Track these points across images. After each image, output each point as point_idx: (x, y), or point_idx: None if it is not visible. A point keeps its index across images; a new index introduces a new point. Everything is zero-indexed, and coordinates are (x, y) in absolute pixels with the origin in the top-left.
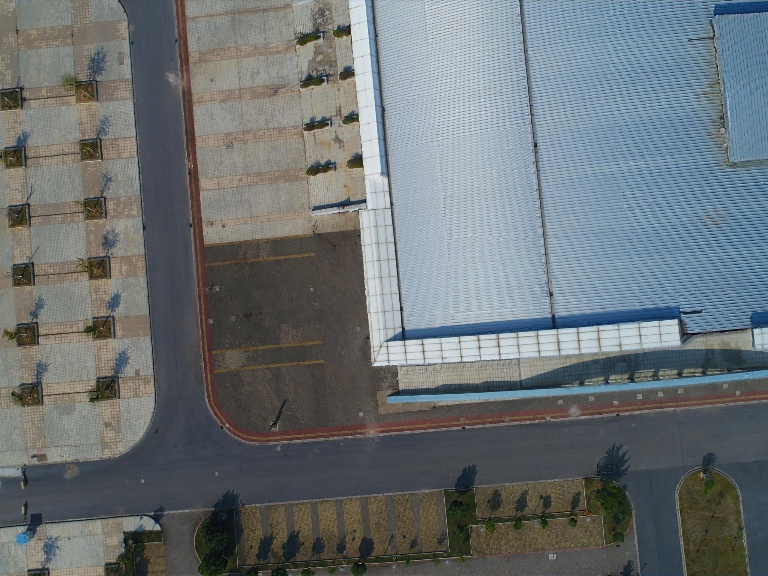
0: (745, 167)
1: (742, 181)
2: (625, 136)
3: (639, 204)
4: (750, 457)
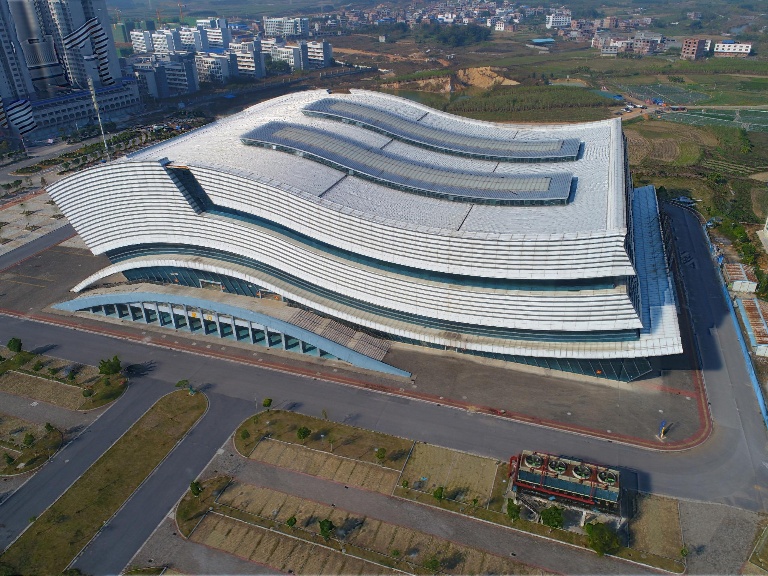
0: None
1: None
2: None
3: None
4: (235, 395)
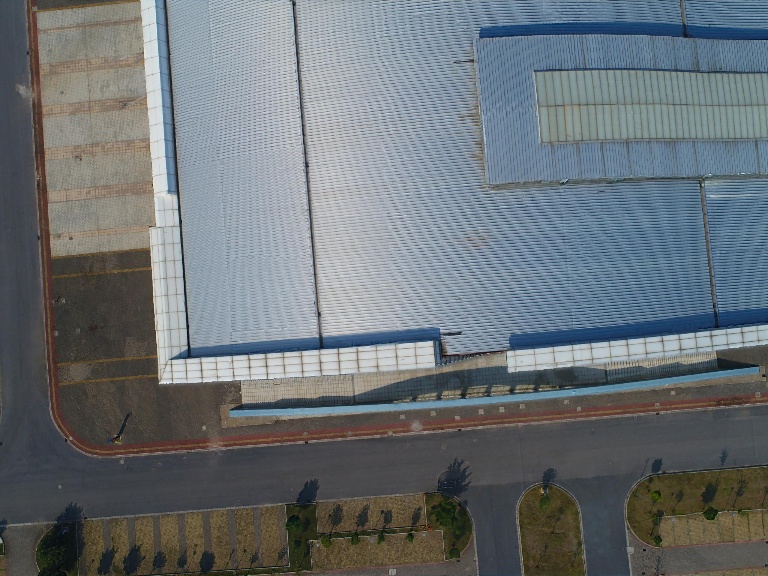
0: (507, 189)
1: (504, 203)
2: (390, 157)
3: (403, 225)
4: (590, 473)
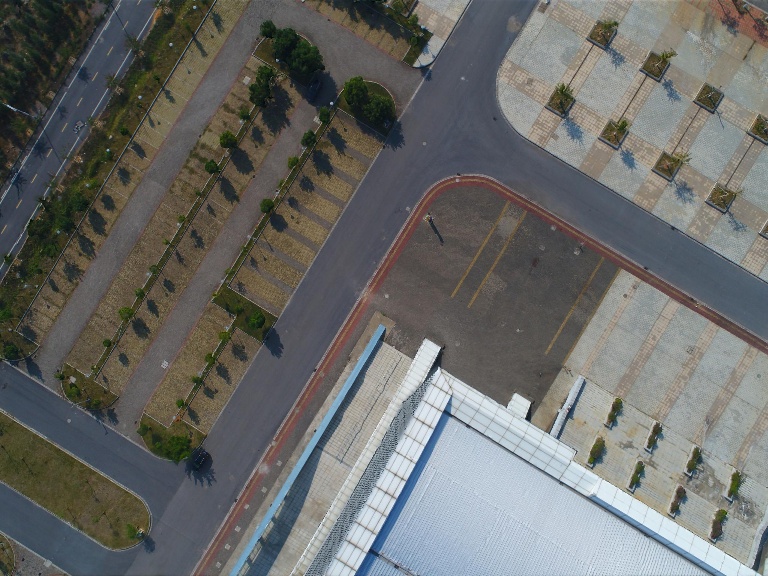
0: None
1: None
2: None
3: None
4: None
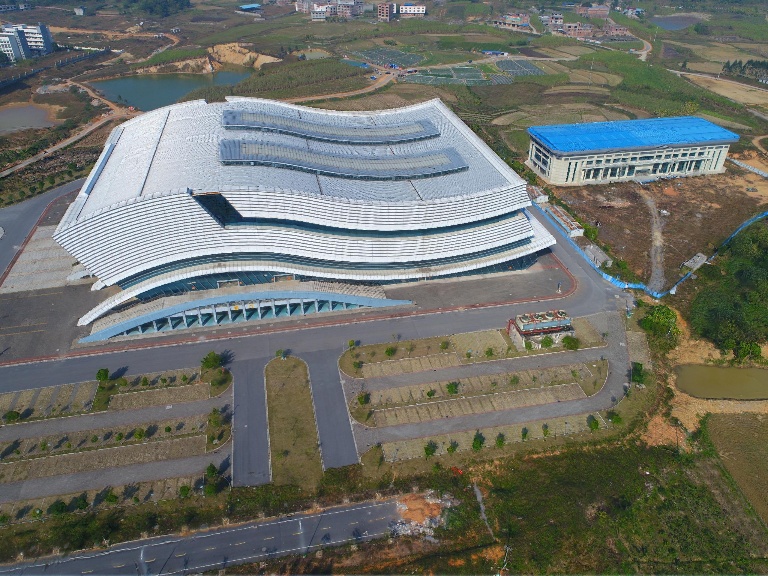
0: None
1: None
2: None
3: None
4: (314, 349)
